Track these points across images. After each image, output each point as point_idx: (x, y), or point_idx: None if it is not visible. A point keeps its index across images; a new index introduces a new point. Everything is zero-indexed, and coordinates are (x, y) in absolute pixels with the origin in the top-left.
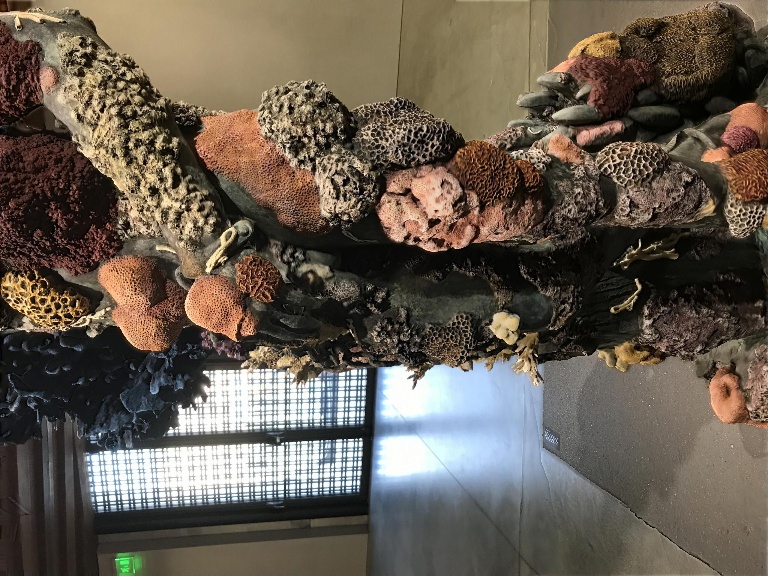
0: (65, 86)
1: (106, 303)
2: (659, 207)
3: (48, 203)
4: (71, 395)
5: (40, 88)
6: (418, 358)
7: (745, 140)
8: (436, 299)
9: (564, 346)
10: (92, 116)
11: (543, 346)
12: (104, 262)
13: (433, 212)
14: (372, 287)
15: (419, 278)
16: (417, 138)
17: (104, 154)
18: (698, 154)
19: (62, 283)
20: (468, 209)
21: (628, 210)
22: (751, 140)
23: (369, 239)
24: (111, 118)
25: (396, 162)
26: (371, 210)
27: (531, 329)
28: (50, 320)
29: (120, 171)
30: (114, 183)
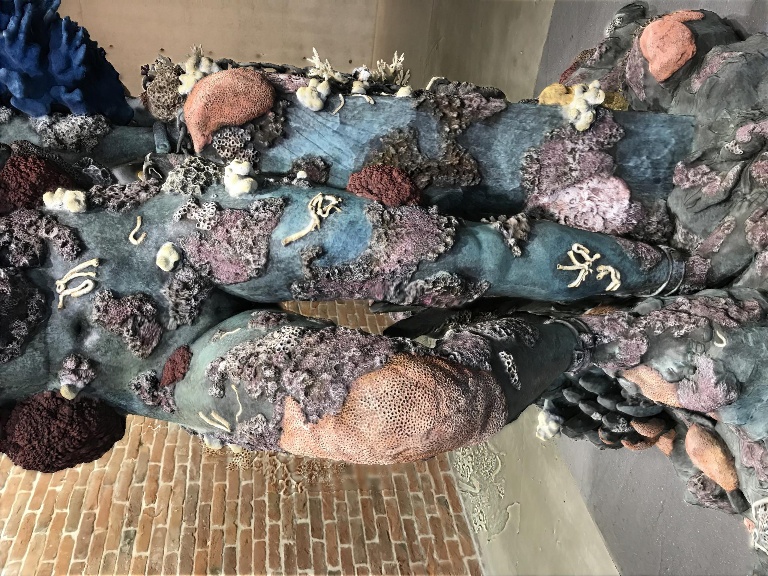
0: None
1: None
2: None
3: None
4: None
5: None
6: (292, 71)
7: None
8: None
9: None
10: None
11: None
12: None
13: None
14: None
15: None
16: None
17: None
18: None
19: None
20: None
21: None
22: None
23: None
24: None
25: None
26: None
27: None
28: None
29: None
30: None
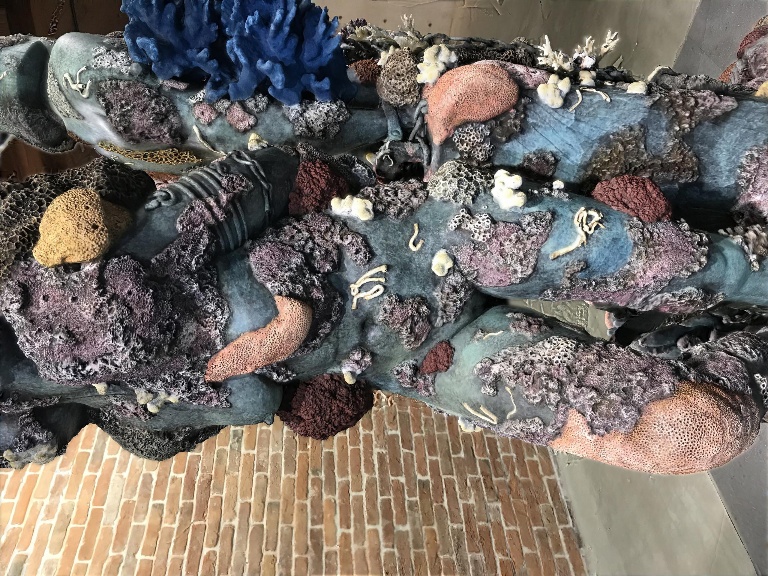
0: None
1: None
2: None
3: None
4: None
5: None
6: None
7: None
8: None
9: None
10: None
11: None
12: None
13: None
14: None
15: None
16: None
17: None
18: None
19: None
20: None
21: None
22: None
23: None
24: None
25: None
26: None
27: None
28: None
29: None
30: None
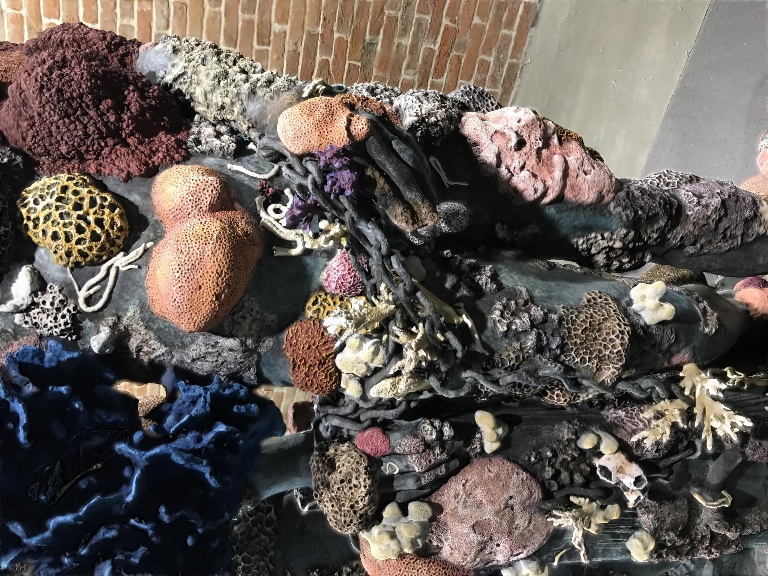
0: (164, 41)
1: (149, 235)
2: (721, 193)
3: (127, 85)
4: (33, 435)
5: (138, 51)
6: None
7: (759, 280)
8: (553, 283)
9: (745, 445)
10: (187, 45)
11: (719, 461)
12: (164, 170)
13: (516, 123)
14: (474, 261)
15: (524, 264)
16: (477, 90)
17: (194, 64)
18: (729, 299)
19: (104, 191)
20: (547, 132)
21: (696, 198)
22: (764, 280)
23: (458, 180)
24: (204, 49)
25: (465, 103)
26: (455, 127)
27: (684, 324)
28: (75, 220)
29: (207, 74)
30: (196, 95)
